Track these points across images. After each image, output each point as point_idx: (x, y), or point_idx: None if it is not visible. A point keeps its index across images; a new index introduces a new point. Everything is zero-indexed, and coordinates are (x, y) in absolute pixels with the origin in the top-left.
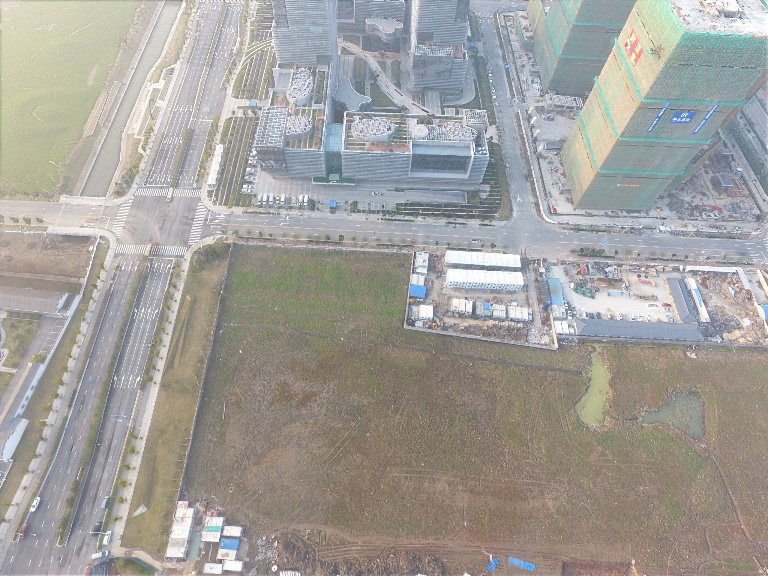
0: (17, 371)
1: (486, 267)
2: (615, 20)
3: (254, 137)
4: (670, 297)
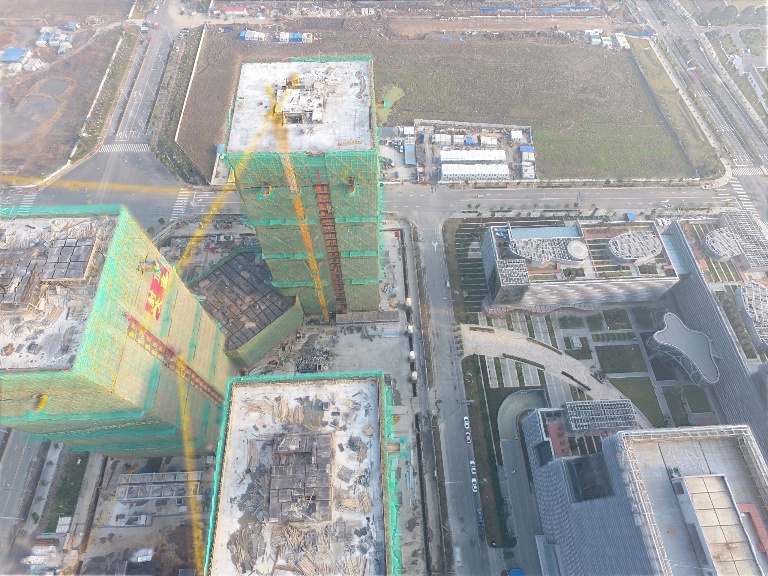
0: None
1: None
2: None
3: None
4: None
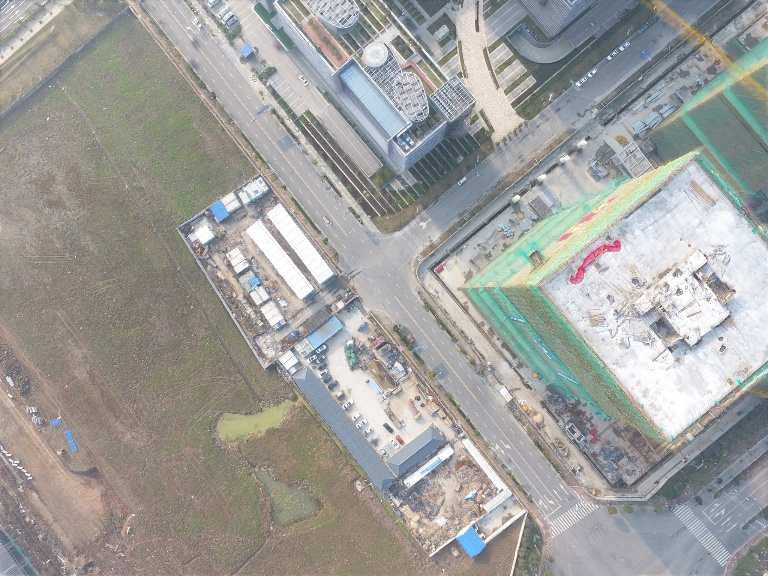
0: None
1: None
2: None
3: None
4: (412, 439)
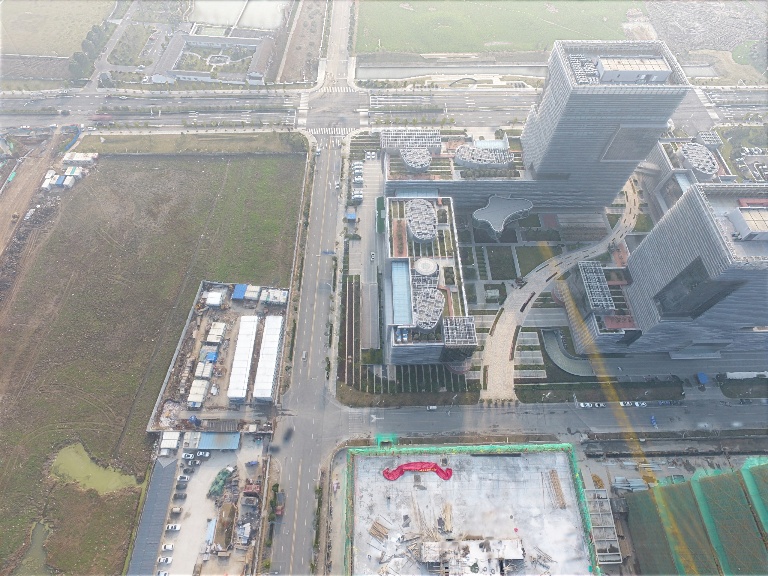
0: None
1: None
2: (738, 575)
3: None
4: None
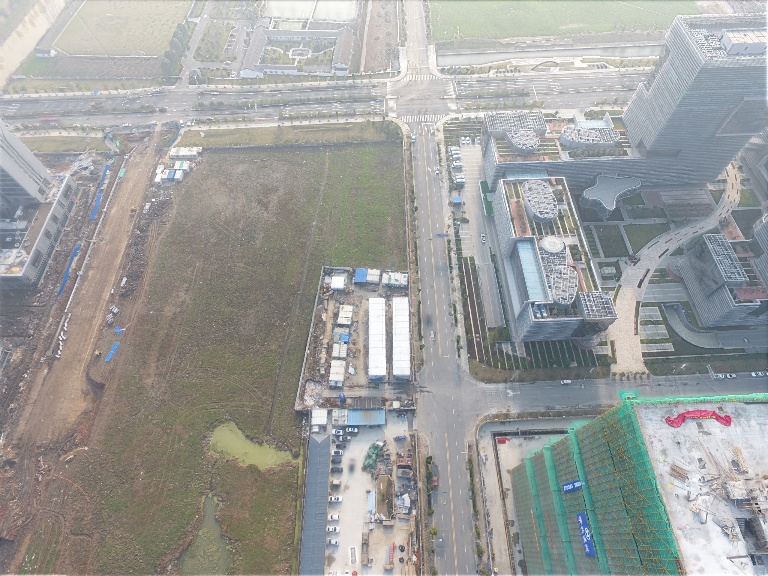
0: None
1: None
2: None
3: None
4: None
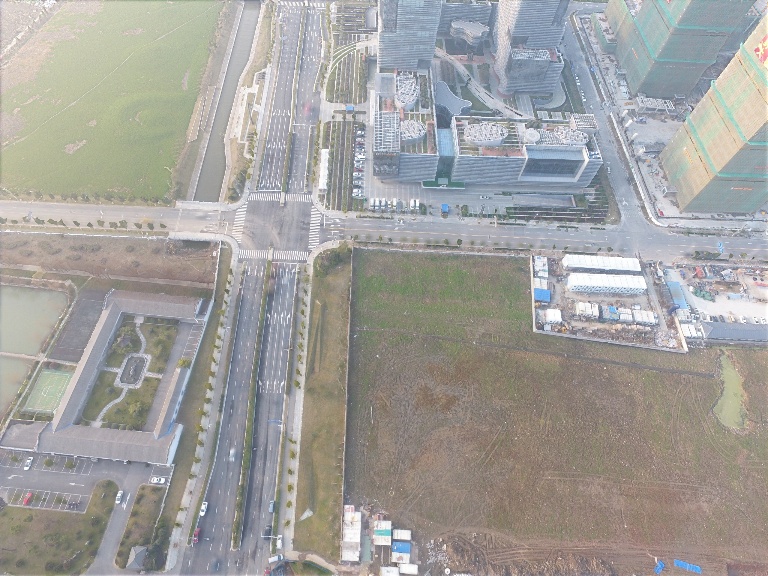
0: (163, 376)
1: (606, 271)
2: (718, 24)
3: (355, 141)
4: None
